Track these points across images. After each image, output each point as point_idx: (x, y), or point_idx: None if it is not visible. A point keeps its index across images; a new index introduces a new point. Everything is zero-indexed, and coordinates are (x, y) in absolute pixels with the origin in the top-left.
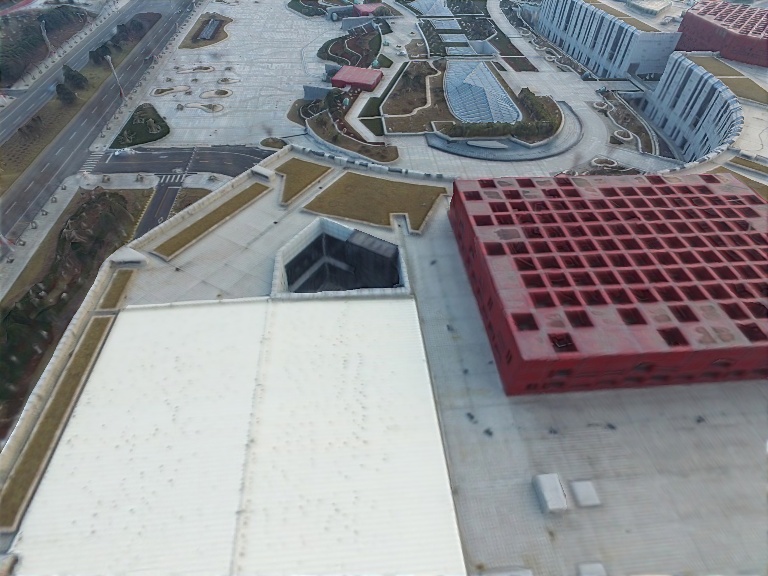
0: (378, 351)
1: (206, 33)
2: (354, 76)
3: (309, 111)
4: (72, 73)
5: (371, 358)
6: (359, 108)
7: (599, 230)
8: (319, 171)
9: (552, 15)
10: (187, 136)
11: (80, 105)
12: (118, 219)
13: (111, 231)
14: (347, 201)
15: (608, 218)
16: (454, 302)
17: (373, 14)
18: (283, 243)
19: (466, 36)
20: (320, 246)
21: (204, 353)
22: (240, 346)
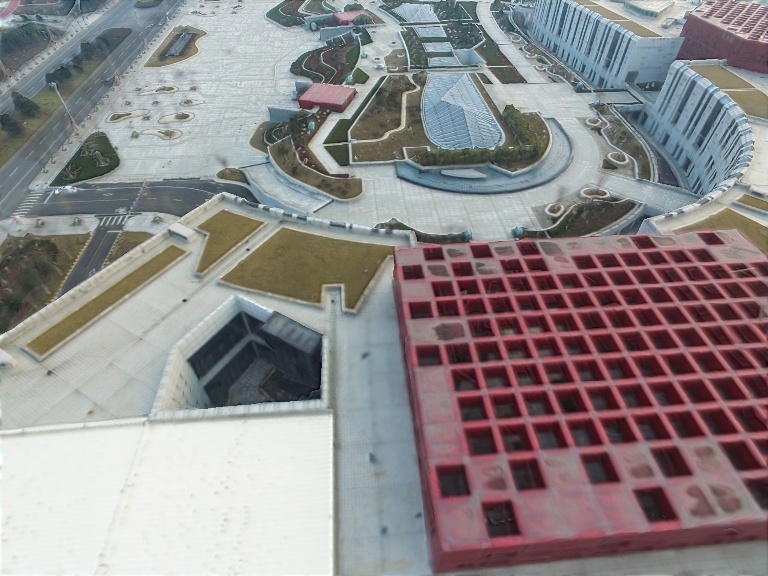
0: (271, 502)
1: (175, 49)
2: (323, 95)
3: (273, 136)
4: (21, 100)
5: (260, 514)
6: (326, 133)
7: (567, 321)
8: (249, 227)
9: (545, 18)
10: (138, 169)
11: (28, 135)
12: (43, 274)
13: (34, 288)
14: (274, 269)
15: (579, 302)
16: (383, 416)
17: (353, 23)
18: (187, 331)
19: (451, 44)
20: (242, 324)
21: (44, 510)
22: (93, 498)
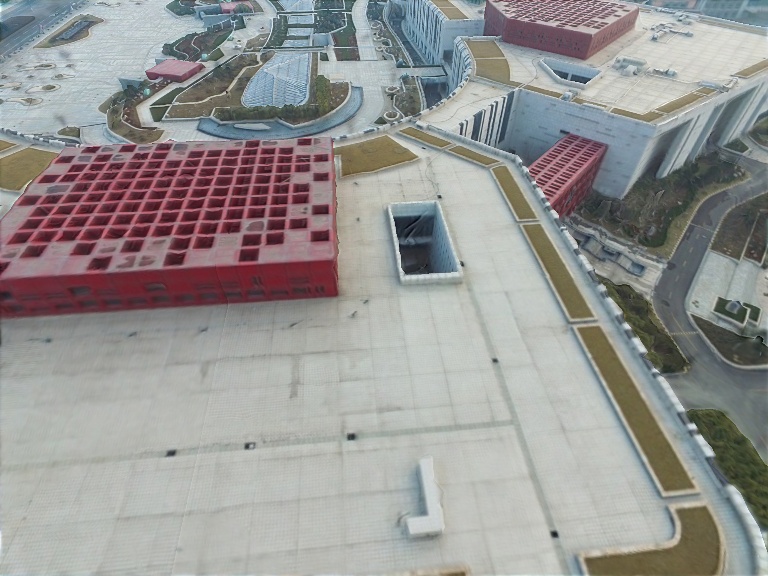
0: None
1: (66, 33)
2: (169, 68)
3: None
4: None
5: None
6: (157, 97)
7: (146, 184)
8: (2, 147)
9: (408, 8)
10: None
11: None
12: None
13: None
14: (1, 171)
15: None
16: None
17: (234, 11)
18: None
19: (314, 30)
20: None
21: None
22: None
